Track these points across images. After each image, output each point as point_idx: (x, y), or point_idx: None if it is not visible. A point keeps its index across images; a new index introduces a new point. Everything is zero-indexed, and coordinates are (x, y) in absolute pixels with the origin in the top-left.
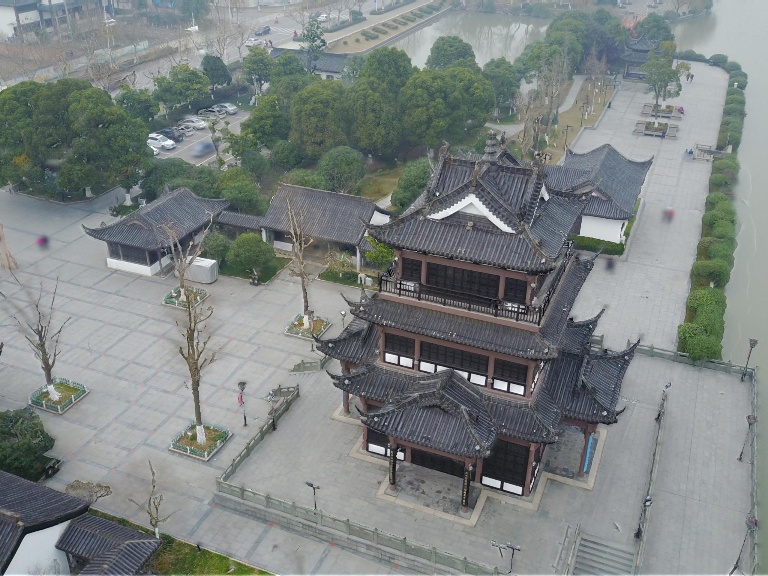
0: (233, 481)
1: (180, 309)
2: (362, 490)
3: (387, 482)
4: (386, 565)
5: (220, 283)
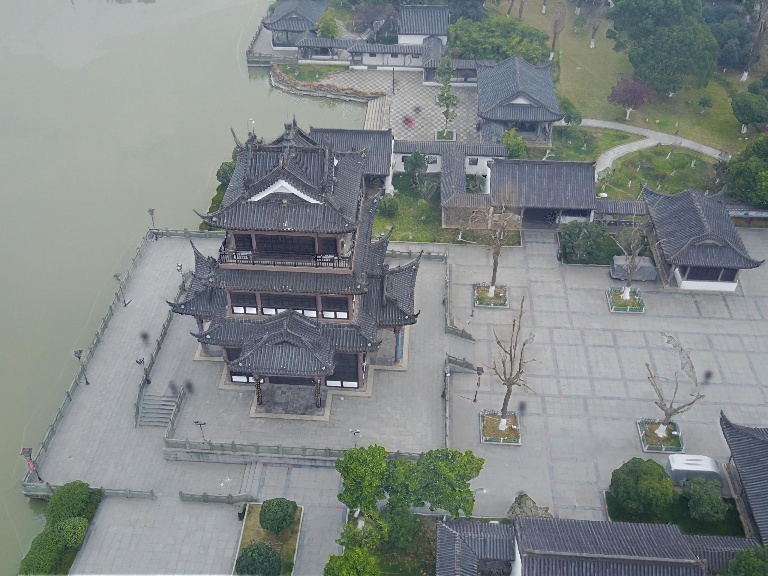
0: (443, 266)
1: None
2: None
3: None
4: None
5: None
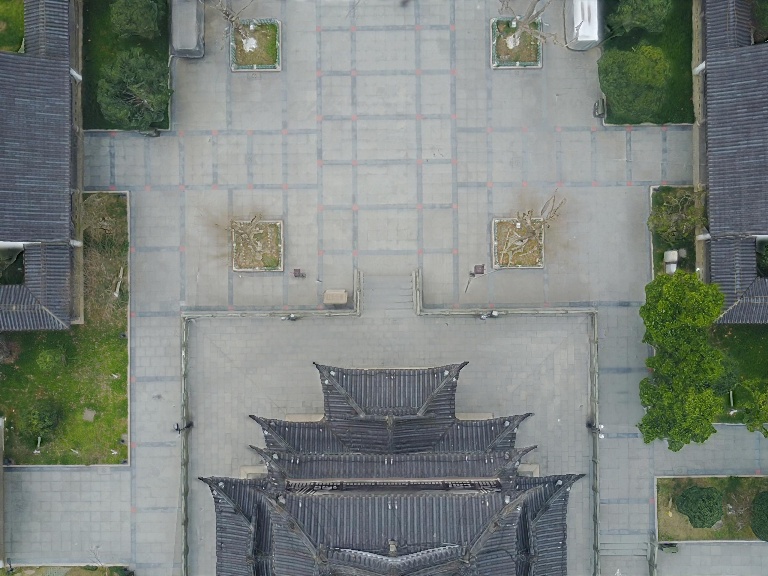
0: (203, 322)
1: (489, 52)
2: (245, 450)
3: (263, 470)
4: (181, 501)
5: (580, 60)
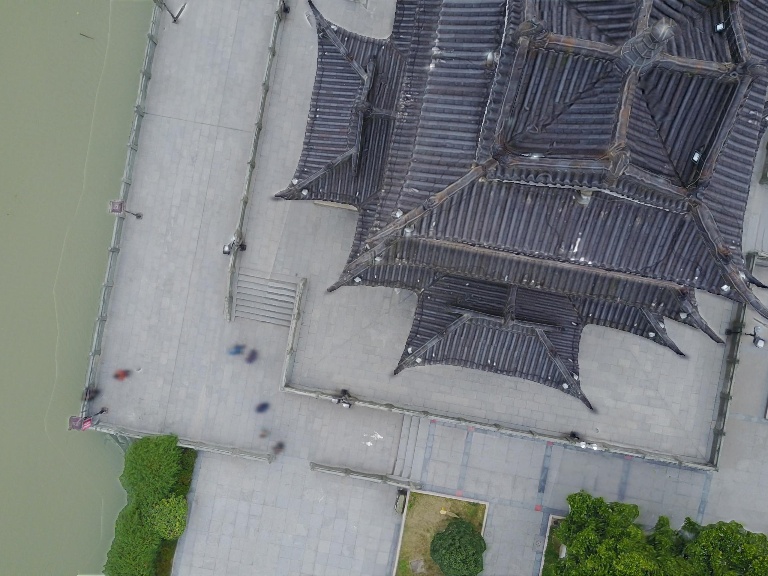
0: None
1: None
2: None
3: None
4: None
5: None
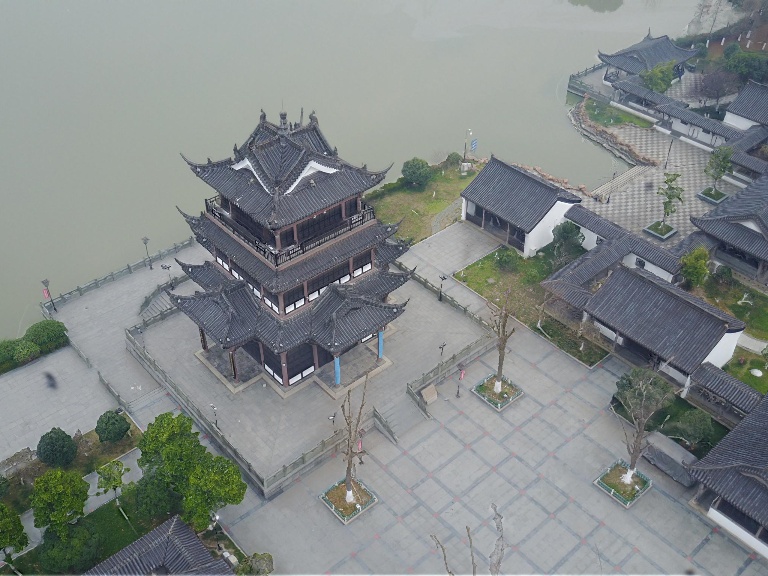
0: None
1: None
2: None
3: None
4: None
5: None
